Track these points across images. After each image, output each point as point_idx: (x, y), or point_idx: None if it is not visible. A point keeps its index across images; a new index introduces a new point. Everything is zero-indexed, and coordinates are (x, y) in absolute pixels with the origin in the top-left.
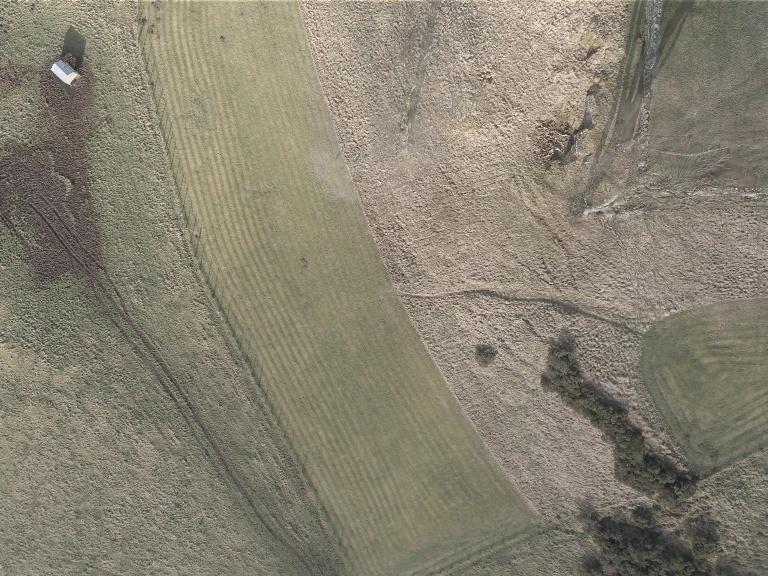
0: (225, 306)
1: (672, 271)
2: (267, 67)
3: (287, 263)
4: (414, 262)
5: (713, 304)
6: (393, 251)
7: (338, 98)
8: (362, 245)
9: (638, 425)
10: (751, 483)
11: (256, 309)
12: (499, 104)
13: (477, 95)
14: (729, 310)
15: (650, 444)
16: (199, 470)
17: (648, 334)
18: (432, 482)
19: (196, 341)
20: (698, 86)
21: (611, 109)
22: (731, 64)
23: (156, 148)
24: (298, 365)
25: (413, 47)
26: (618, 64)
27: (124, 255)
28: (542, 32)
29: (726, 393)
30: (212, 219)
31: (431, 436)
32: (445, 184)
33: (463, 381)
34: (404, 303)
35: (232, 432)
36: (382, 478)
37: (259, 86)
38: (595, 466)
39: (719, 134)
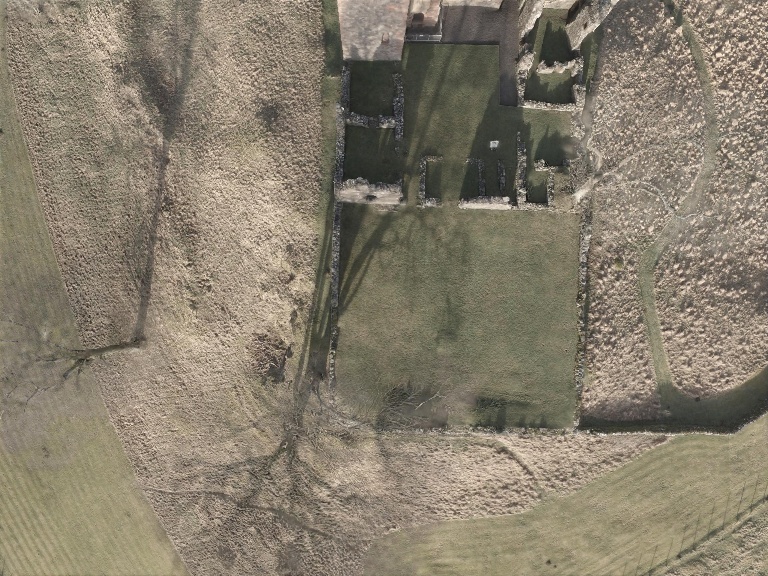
0: None
1: (385, 493)
2: (4, 249)
3: (27, 452)
4: (155, 457)
5: (430, 524)
6: (135, 444)
7: (76, 285)
8: (103, 436)
9: None
10: None
11: None
12: (218, 313)
13: (197, 302)
14: (446, 530)
15: None
16: None
17: (370, 552)
18: None
19: None
20: (388, 321)
21: (304, 342)
22: (421, 299)
23: None
24: (42, 558)
25: (142, 243)
26: (311, 296)
27: None
28: (251, 249)
29: None
30: None
31: None
32: (176, 384)
33: None
34: (148, 497)
35: None
36: None
37: None
38: None
39: (410, 370)
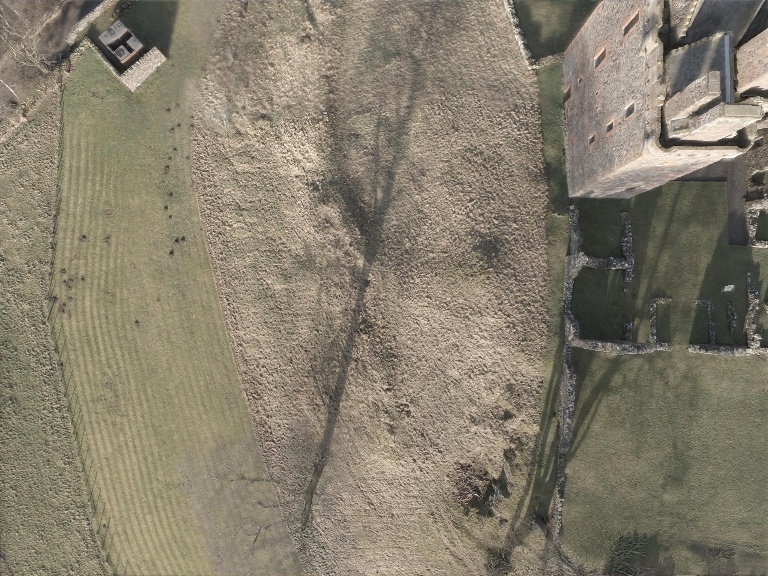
0: None
1: None
2: (184, 356)
3: (201, 558)
4: (333, 570)
5: None
6: (312, 556)
7: (257, 394)
8: (280, 547)
9: None
10: None
11: None
12: (417, 439)
13: (395, 427)
14: None
15: None
16: None
17: None
18: None
19: None
20: (614, 467)
21: (526, 485)
22: (648, 444)
23: (64, 432)
24: None
25: (332, 361)
26: (533, 437)
27: (25, 543)
28: (460, 380)
29: None
30: (122, 509)
31: None
32: (364, 503)
33: None
34: None
35: None
36: None
37: (175, 375)
38: None
39: (636, 517)
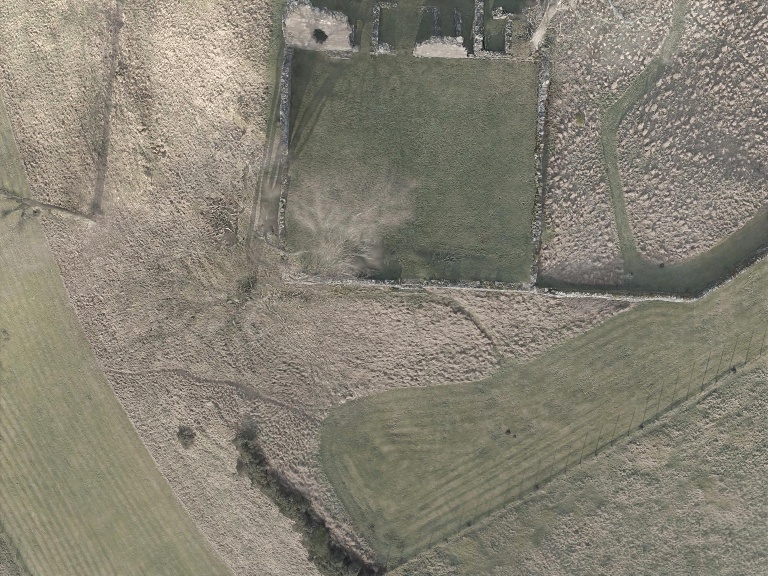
0: None
1: (341, 358)
2: None
3: None
4: (115, 337)
5: (387, 391)
6: (94, 325)
7: (35, 163)
8: (63, 318)
9: (321, 516)
10: (437, 574)
11: None
12: (173, 179)
13: (152, 169)
14: (403, 398)
15: (336, 535)
16: None
17: (327, 421)
18: (149, 567)
19: None
20: (340, 173)
21: (254, 194)
22: (375, 150)
23: None
24: (5, 443)
25: (98, 114)
26: (262, 147)
27: None
28: (204, 108)
29: (408, 482)
30: None
31: (145, 518)
32: (133, 258)
33: (171, 462)
34: (108, 379)
35: None
36: (99, 562)
37: None
38: (298, 553)
39: (362, 222)
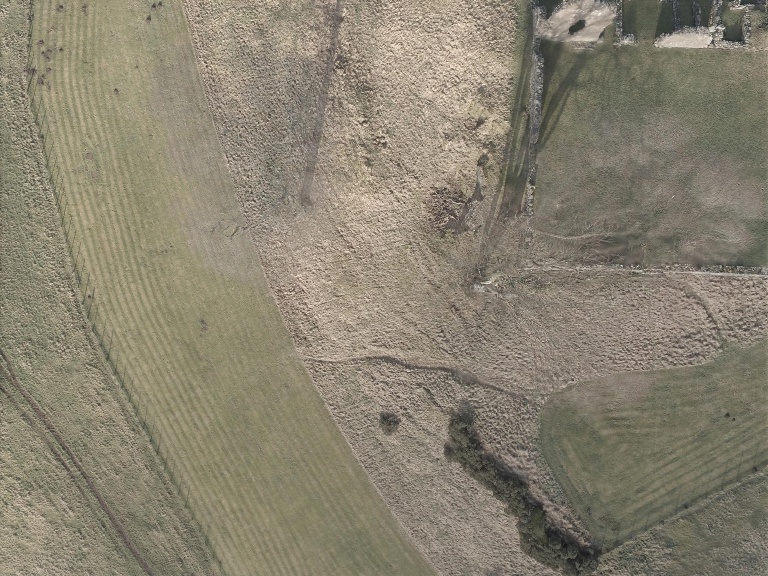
0: (120, 370)
1: (567, 343)
2: (163, 122)
3: (186, 325)
4: (316, 326)
5: (609, 376)
6: (295, 314)
7: (237, 155)
8: (263, 307)
9: (539, 499)
10: (653, 556)
11: (153, 373)
12: (394, 169)
13: (372, 159)
14: (625, 382)
15: (552, 518)
16: (95, 543)
17: (547, 406)
18: (340, 552)
19: (90, 407)
20: (584, 160)
21: (498, 182)
22: (616, 138)
23: (46, 204)
24: (199, 431)
25: (310, 107)
26: (505, 136)
27: (11, 316)
28: (433, 99)
29: (626, 465)
30: (106, 279)
31: (338, 505)
32: (344, 248)
33: (368, 448)
34: (307, 367)
35: (130, 502)
36: (288, 549)
37: (155, 141)
38: (501, 537)
39: (605, 209)
